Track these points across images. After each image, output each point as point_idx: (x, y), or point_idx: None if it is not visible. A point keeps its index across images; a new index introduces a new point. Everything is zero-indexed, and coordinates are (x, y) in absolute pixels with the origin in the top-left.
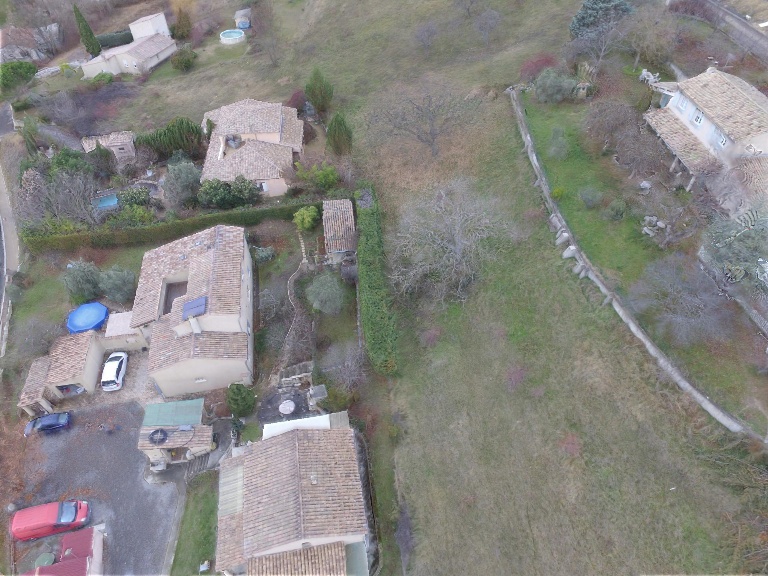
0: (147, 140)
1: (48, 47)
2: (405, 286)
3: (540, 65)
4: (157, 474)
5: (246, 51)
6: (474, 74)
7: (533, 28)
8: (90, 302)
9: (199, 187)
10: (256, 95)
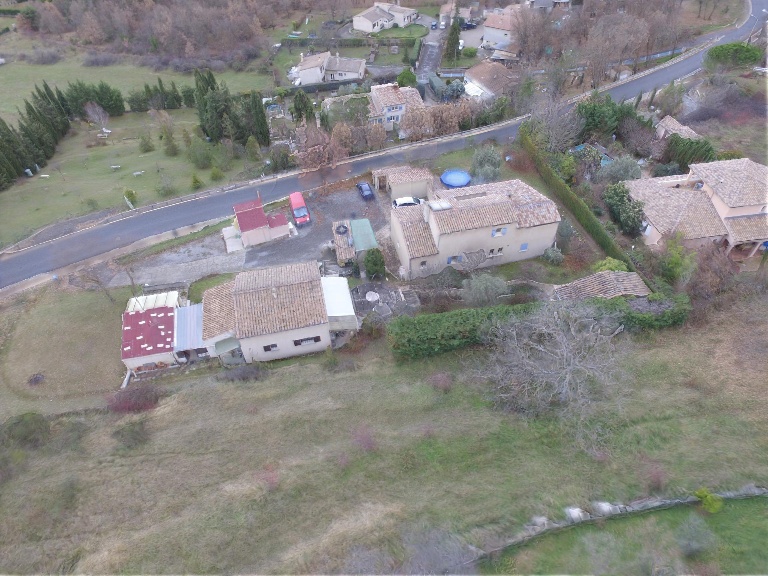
0: (674, 140)
1: None
2: None
3: None
4: None
5: None
6: None
7: None
8: None
9: None
10: None
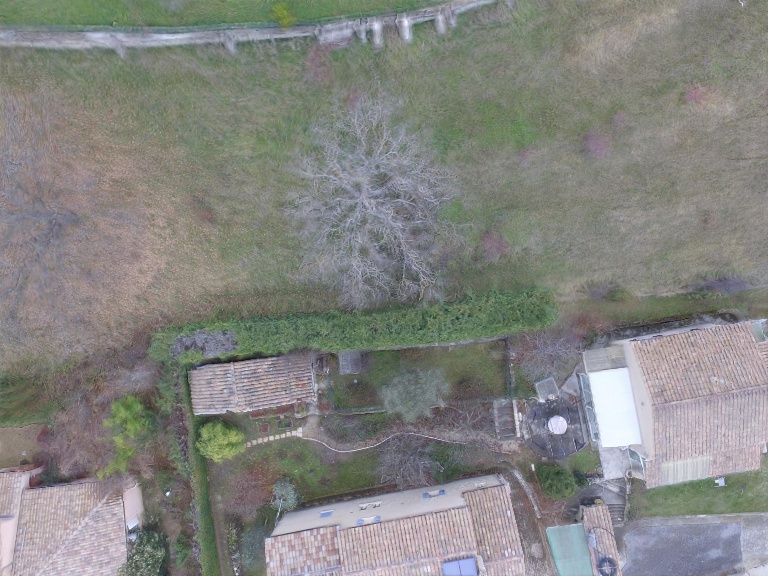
0: None
1: None
2: None
3: None
4: None
5: None
6: None
7: None
8: None
9: None
10: None
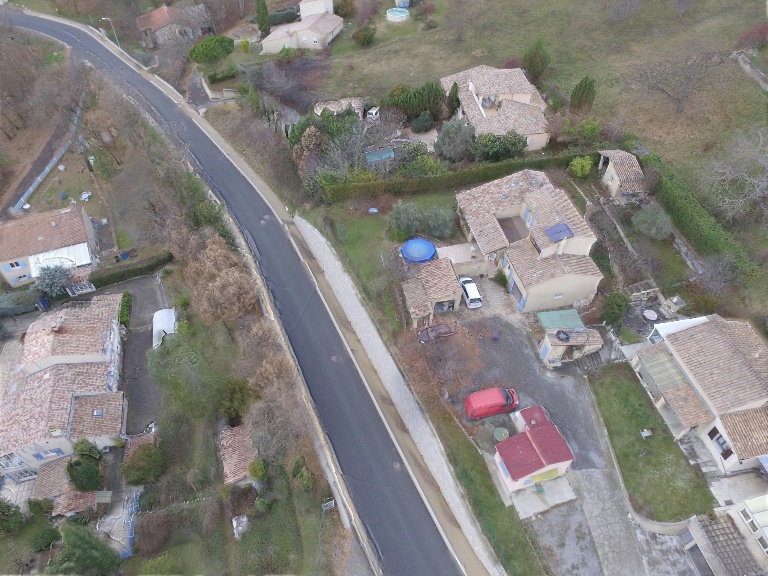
0: (396, 102)
1: (210, 26)
2: (733, 214)
3: (767, 32)
4: (553, 370)
5: (420, 27)
6: (683, 43)
7: (723, 2)
8: (409, 239)
9: (470, 141)
10: (456, 66)
